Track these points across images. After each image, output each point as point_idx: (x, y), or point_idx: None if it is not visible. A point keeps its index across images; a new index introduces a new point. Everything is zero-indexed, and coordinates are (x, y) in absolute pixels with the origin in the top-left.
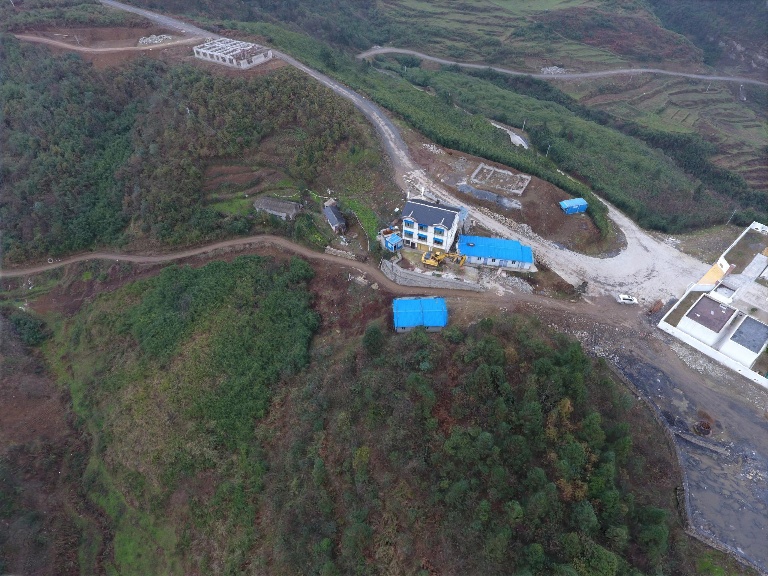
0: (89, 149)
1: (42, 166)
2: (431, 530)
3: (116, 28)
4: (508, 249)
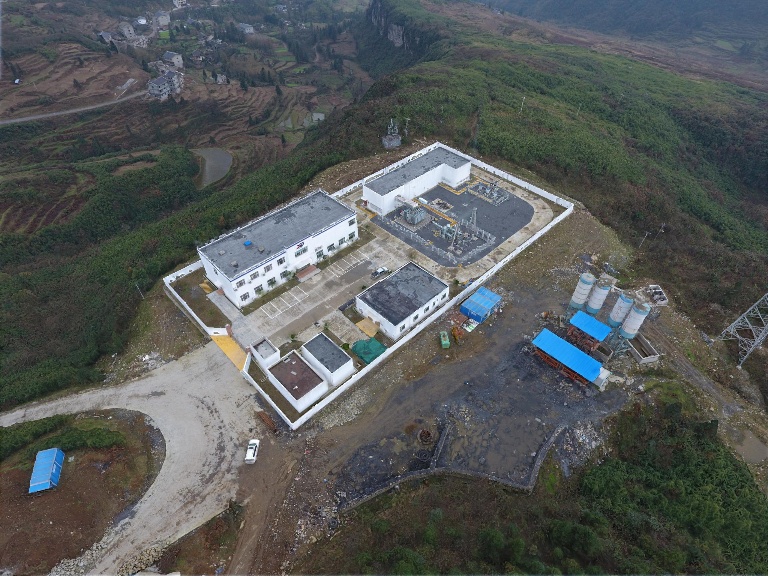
0: None
1: None
2: None
3: None
4: None
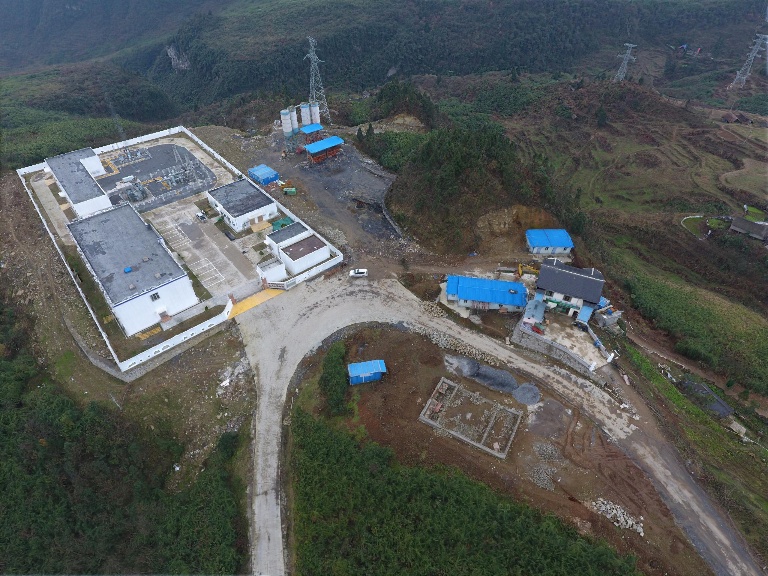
0: None
1: None
2: None
3: None
4: (473, 286)
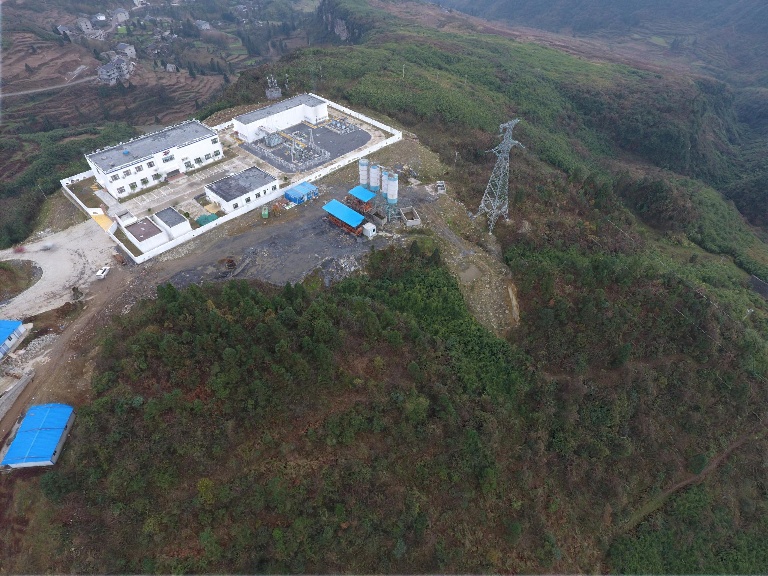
0: None
1: None
2: (280, 426)
3: None
4: None
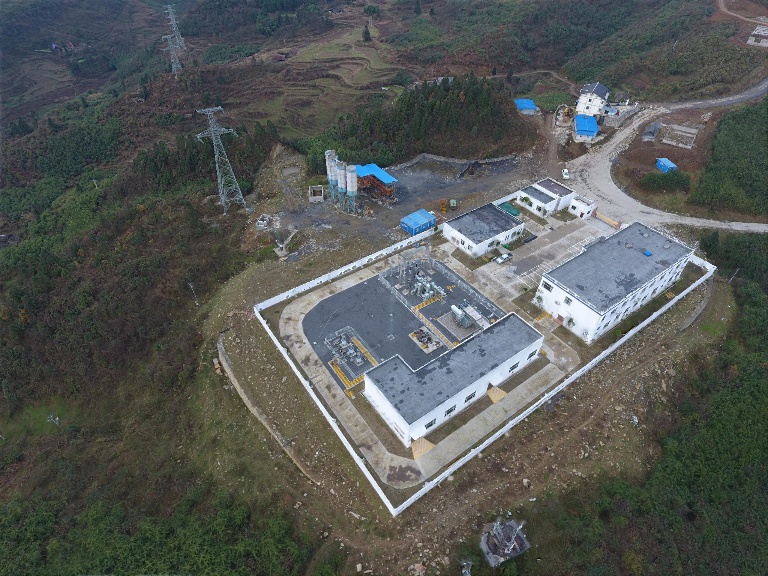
0: (638, 48)
1: (615, 44)
2: None
3: (760, 6)
4: None
